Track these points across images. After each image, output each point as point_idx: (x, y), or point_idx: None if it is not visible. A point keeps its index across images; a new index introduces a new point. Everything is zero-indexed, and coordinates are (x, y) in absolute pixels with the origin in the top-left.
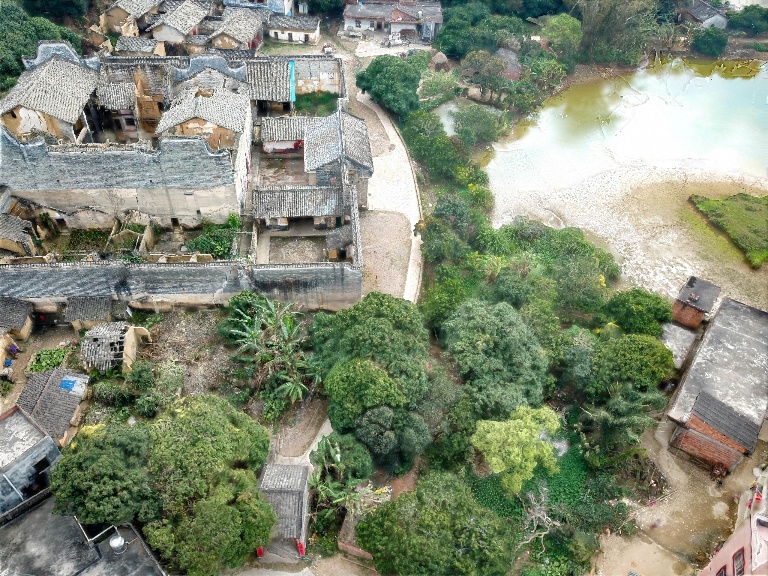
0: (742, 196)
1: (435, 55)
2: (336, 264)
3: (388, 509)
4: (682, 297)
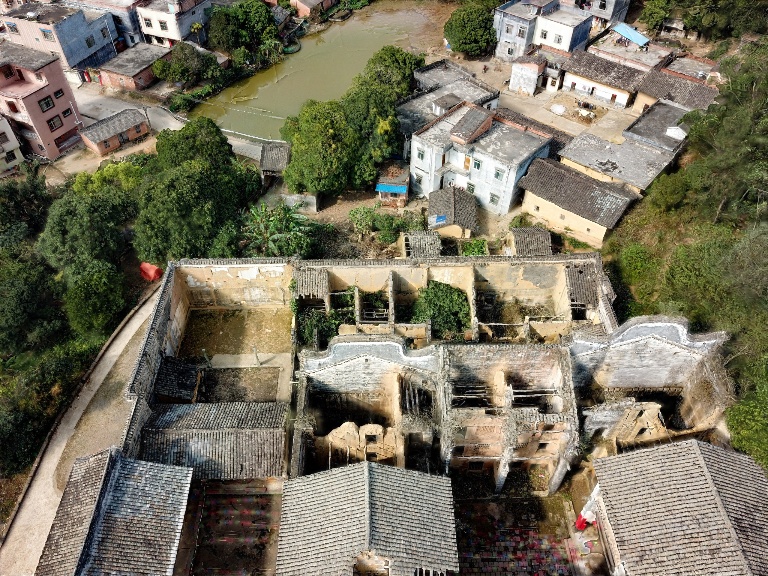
0: None
1: None
2: (196, 259)
3: (216, 148)
4: None
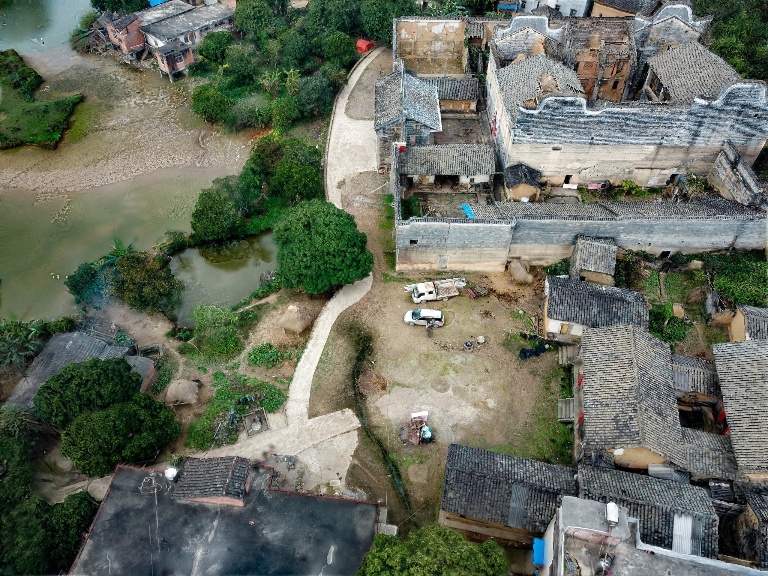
0: (4, 139)
1: (191, 391)
2: (410, 16)
3: None
4: (187, 46)
